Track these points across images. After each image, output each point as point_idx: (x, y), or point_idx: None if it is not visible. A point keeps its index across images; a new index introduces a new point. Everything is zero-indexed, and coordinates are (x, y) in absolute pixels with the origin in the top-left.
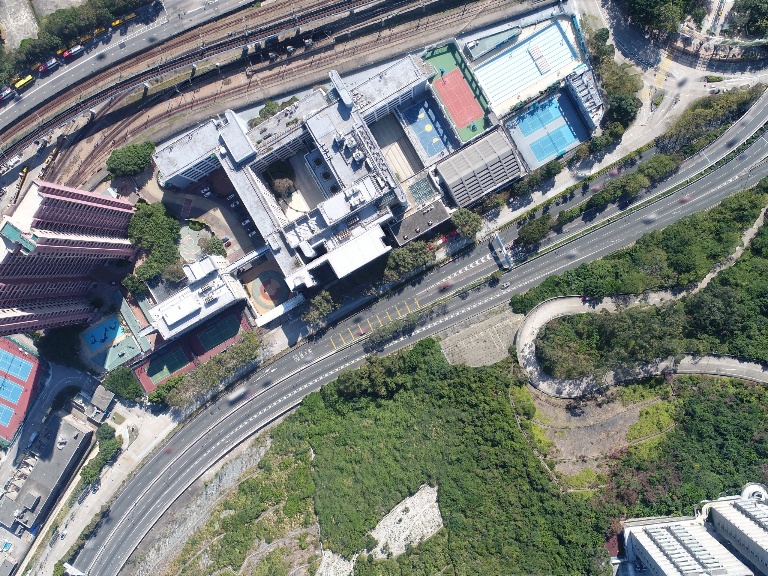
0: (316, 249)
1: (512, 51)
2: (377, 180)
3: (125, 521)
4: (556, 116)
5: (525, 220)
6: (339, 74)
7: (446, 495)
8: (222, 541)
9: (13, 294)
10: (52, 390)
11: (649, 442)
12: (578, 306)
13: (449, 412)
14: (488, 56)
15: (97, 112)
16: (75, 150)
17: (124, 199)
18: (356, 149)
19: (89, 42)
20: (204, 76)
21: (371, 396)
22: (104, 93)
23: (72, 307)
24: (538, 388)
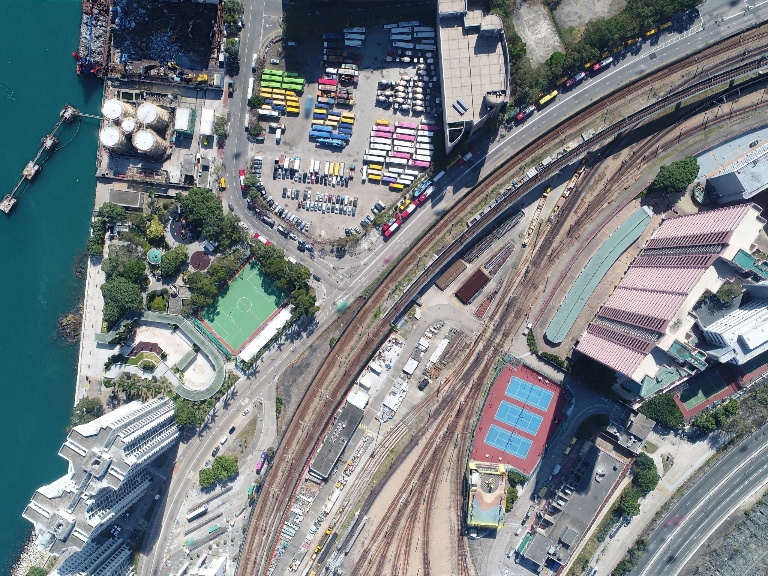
0: None
1: None
2: None
3: (661, 554)
4: None
5: None
6: None
7: None
8: None
9: None
10: (574, 419)
11: None
12: None
13: None
14: None
15: None
16: (601, 167)
17: (655, 217)
18: None
19: (617, 53)
20: None
21: None
22: (651, 107)
23: None
24: None
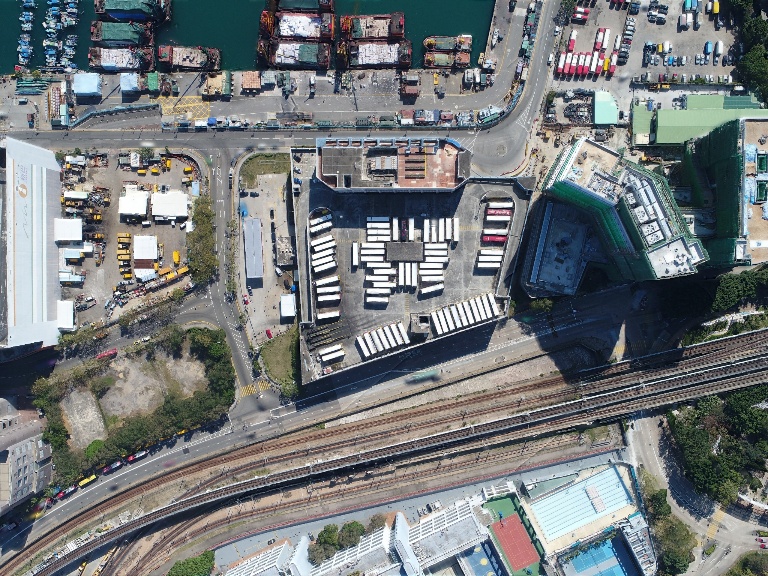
0: None
1: (569, 488)
2: None
3: None
4: (609, 556)
5: None
6: (398, 499)
7: None
8: None
9: None
10: None
11: None
12: None
13: None
14: (545, 493)
15: None
16: (134, 547)
17: None
18: None
19: (154, 445)
20: (265, 488)
21: None
22: (167, 508)
23: None
24: None
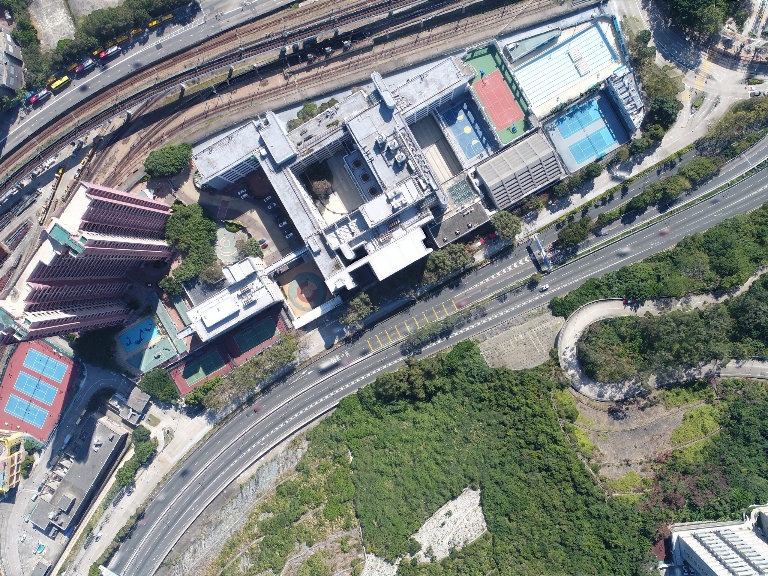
0: (355, 251)
1: (551, 53)
2: (419, 182)
3: (160, 523)
4: (596, 118)
5: (564, 222)
6: None
7: (490, 499)
8: (262, 544)
9: (56, 296)
10: (87, 392)
11: (694, 446)
12: (620, 309)
13: (490, 415)
14: (527, 58)
15: (133, 113)
16: (111, 151)
17: (160, 200)
18: (398, 151)
19: (126, 43)
20: (241, 77)
21: (409, 399)
22: (142, 94)
23: (110, 309)
24: (579, 391)
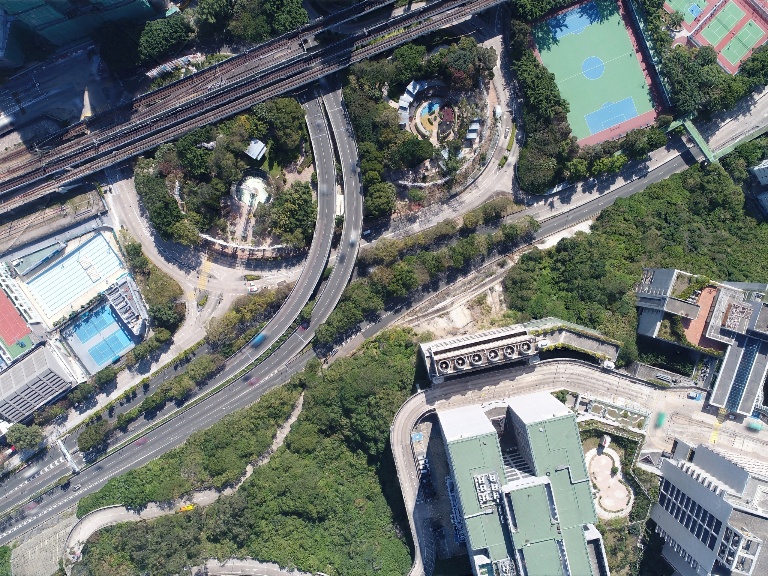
0: None
1: (63, 262)
2: None
3: None
4: (110, 322)
5: (93, 422)
6: None
7: None
8: None
9: None
10: None
11: None
12: (123, 514)
13: None
14: (38, 269)
15: None
16: None
17: None
18: None
19: None
20: None
21: None
22: None
23: None
24: None
